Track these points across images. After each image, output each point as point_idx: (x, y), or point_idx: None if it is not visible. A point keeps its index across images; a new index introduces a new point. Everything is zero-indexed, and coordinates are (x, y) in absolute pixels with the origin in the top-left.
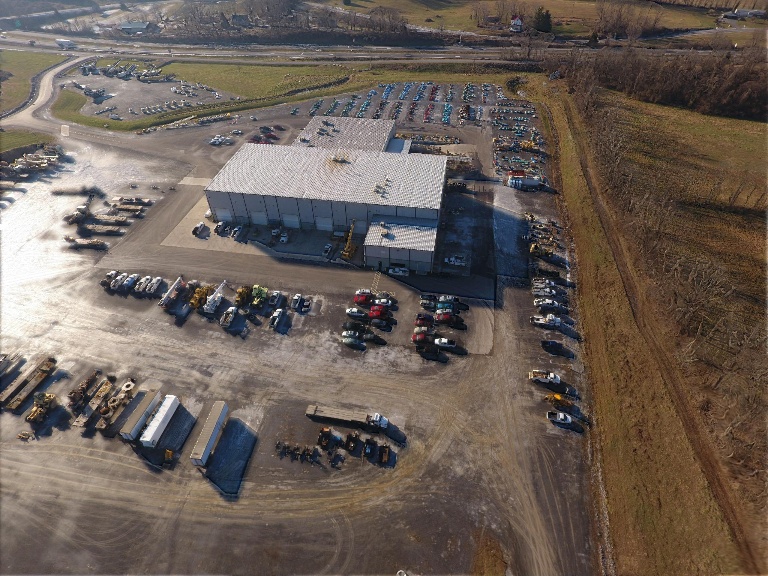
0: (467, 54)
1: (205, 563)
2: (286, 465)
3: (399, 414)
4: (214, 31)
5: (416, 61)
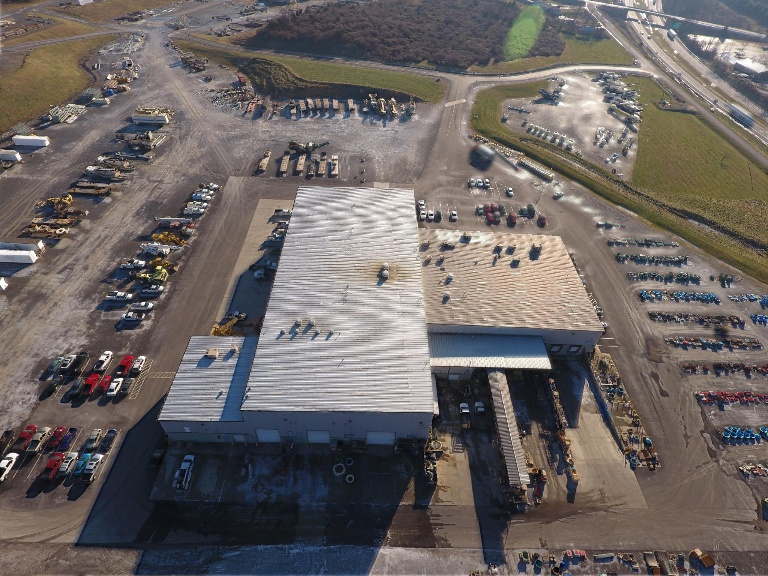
0: None
1: None
2: None
3: None
4: None
5: None
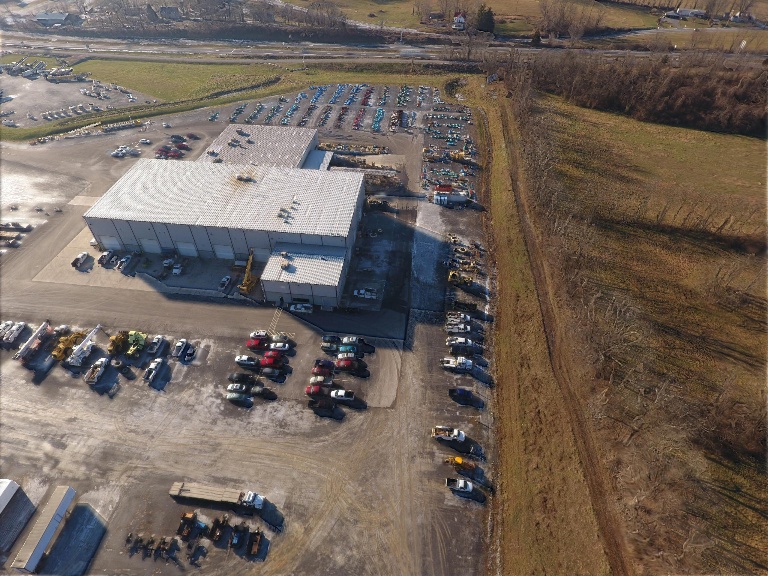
0: (407, 53)
1: None
2: (135, 565)
3: (279, 488)
4: (140, 24)
5: (353, 60)
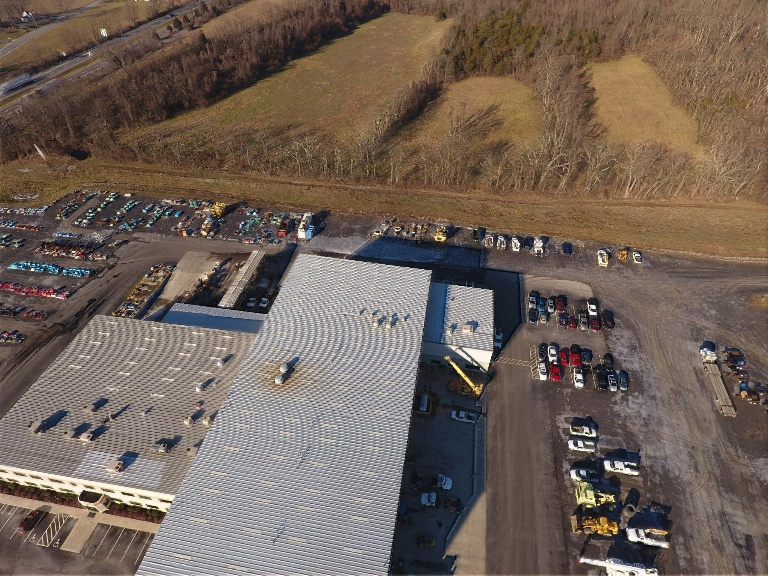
0: None
1: None
2: None
3: (687, 345)
4: None
5: None
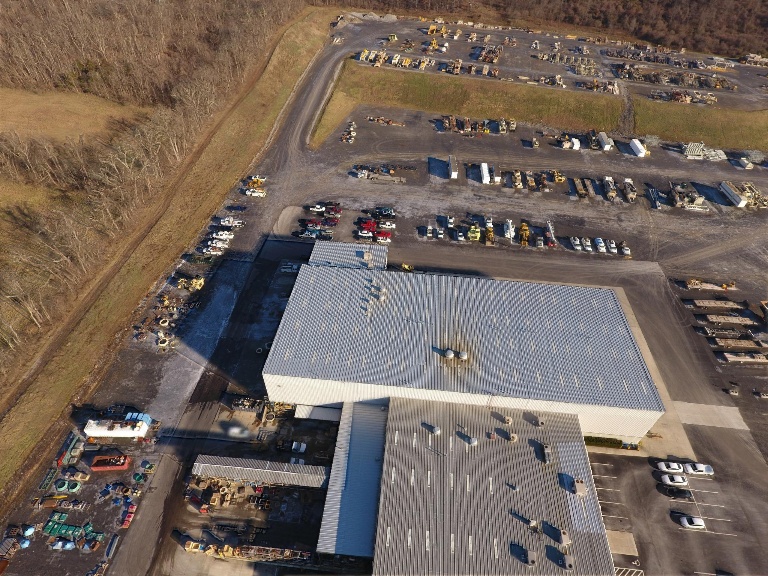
0: None
1: (430, 144)
2: None
3: (352, 181)
4: None
5: None
